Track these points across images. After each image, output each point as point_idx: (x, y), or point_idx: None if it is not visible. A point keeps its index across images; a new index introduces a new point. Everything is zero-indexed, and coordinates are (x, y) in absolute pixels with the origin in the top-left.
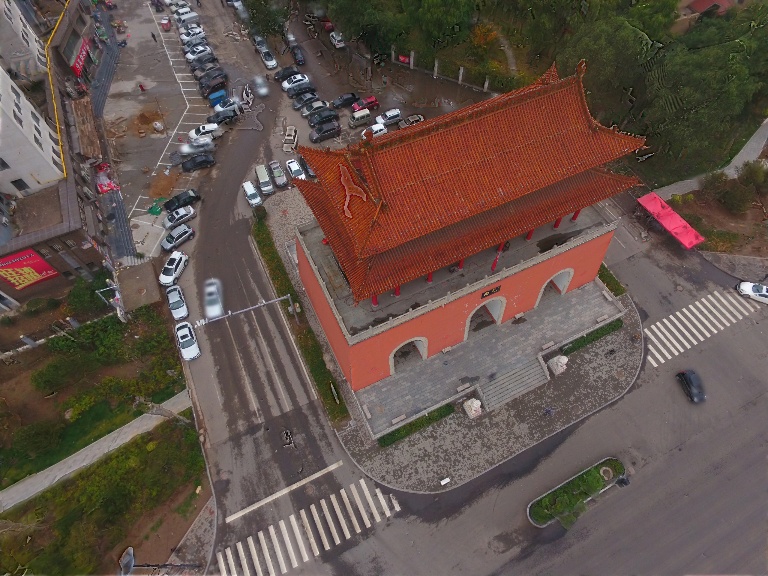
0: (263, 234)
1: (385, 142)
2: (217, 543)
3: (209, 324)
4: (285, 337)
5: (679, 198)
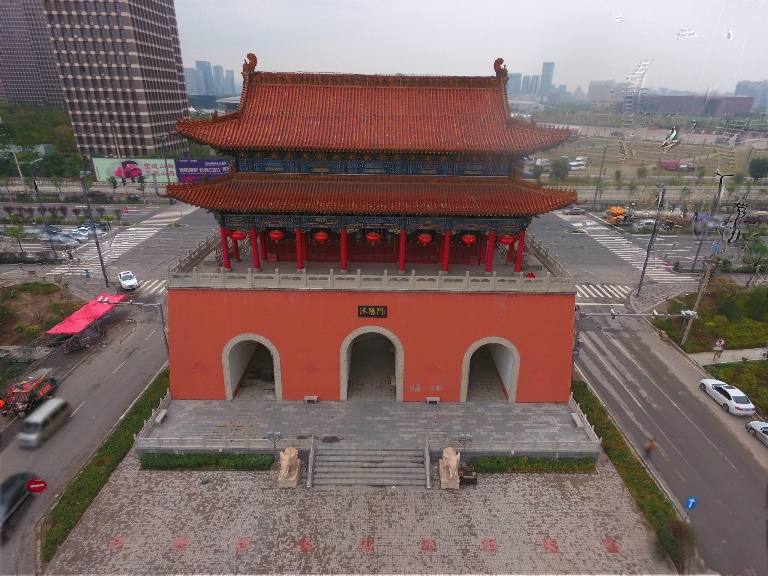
0: (654, 501)
1: (480, 79)
2: (628, 300)
3: (704, 411)
4: (587, 372)
5: (35, 326)
